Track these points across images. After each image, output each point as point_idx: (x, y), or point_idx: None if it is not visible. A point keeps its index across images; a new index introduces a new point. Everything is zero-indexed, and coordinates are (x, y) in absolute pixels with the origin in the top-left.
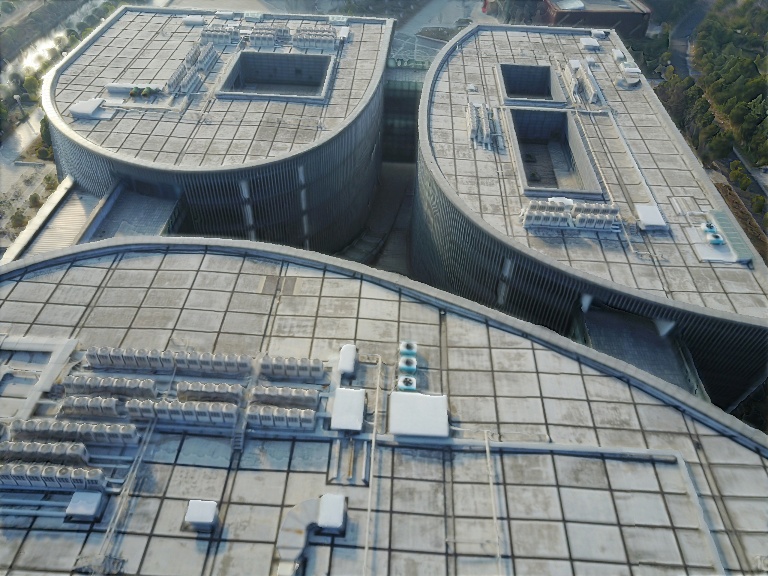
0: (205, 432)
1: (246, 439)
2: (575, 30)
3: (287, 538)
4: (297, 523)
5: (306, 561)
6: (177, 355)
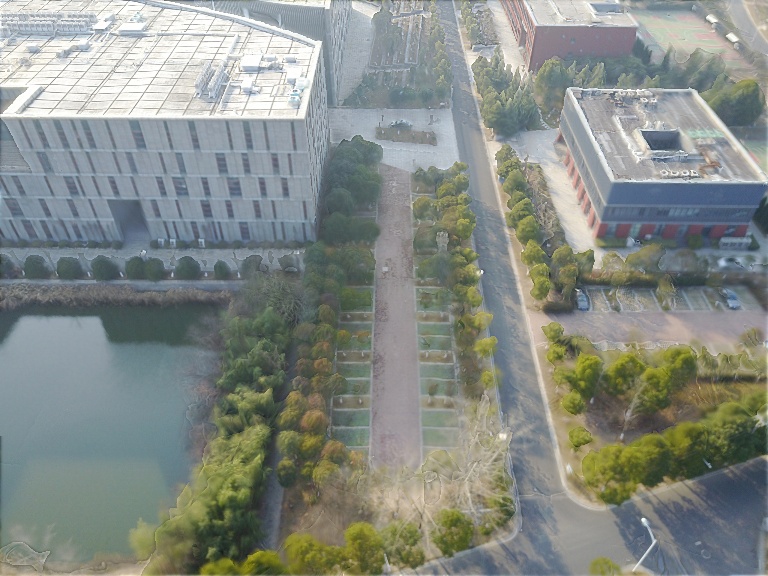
0: (40, 34)
1: (56, 34)
2: None
3: (63, 47)
4: (68, 45)
5: (69, 54)
6: (31, 12)
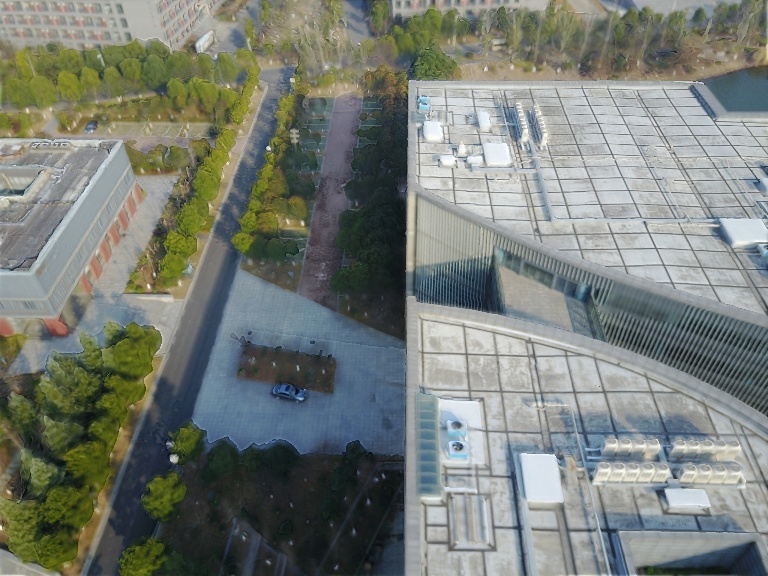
0: None
1: None
2: None
3: None
4: None
5: (767, 174)
6: None
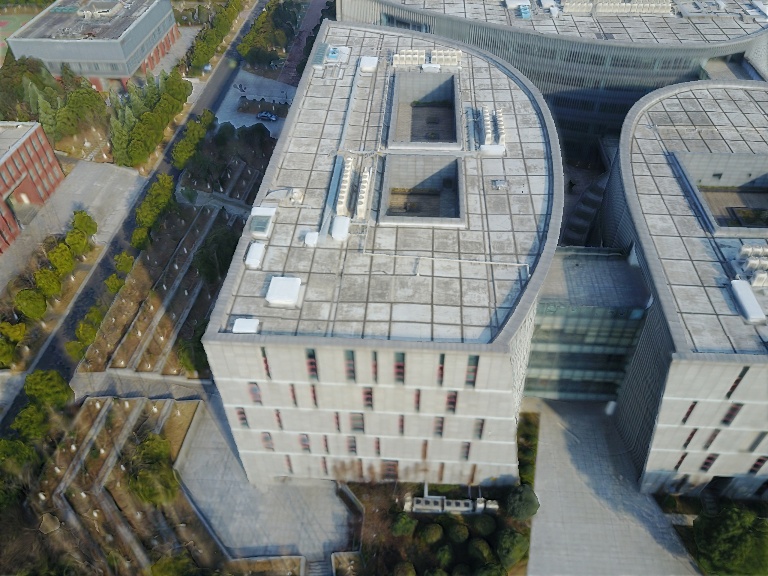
0: None
1: None
2: (288, 337)
3: None
4: None
5: None
6: None
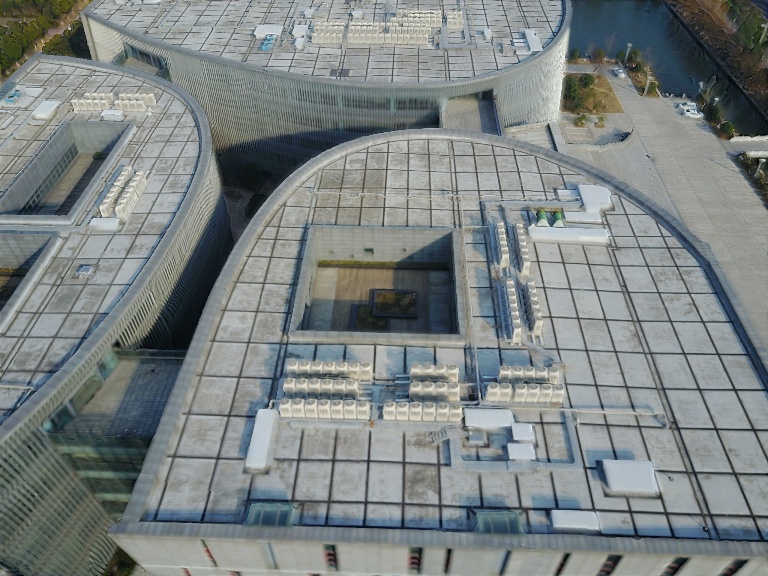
0: None
1: None
2: None
3: (325, 8)
4: None
5: None
6: None
